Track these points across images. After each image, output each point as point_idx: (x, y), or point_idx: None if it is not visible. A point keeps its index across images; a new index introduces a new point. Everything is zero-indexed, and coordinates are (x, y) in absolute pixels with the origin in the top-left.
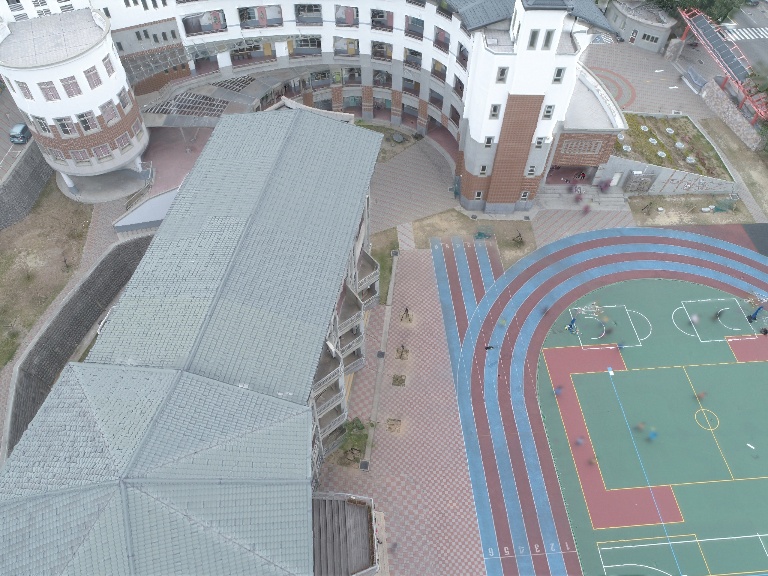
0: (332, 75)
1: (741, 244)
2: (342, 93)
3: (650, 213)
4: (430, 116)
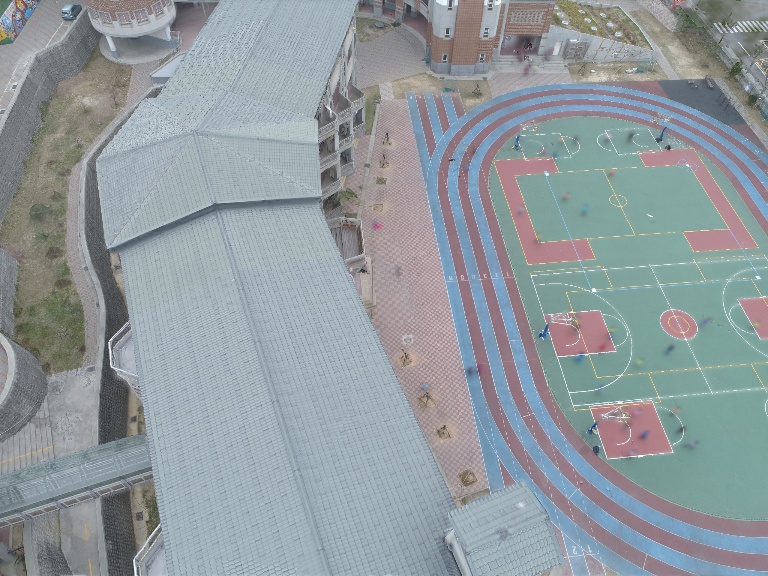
0: None
1: (656, 93)
2: None
3: (584, 74)
4: (405, 3)
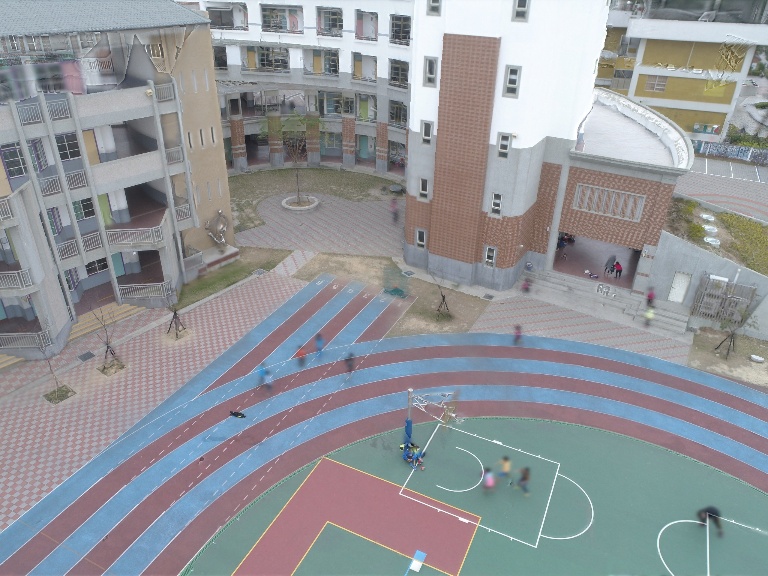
0: (345, 101)
1: None
2: (355, 128)
3: (730, 357)
4: None
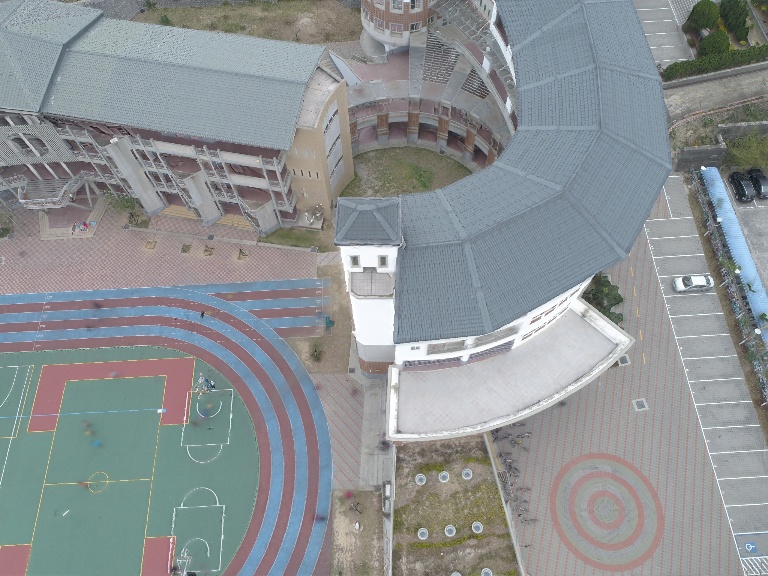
0: None
1: None
2: None
3: (353, 511)
4: None
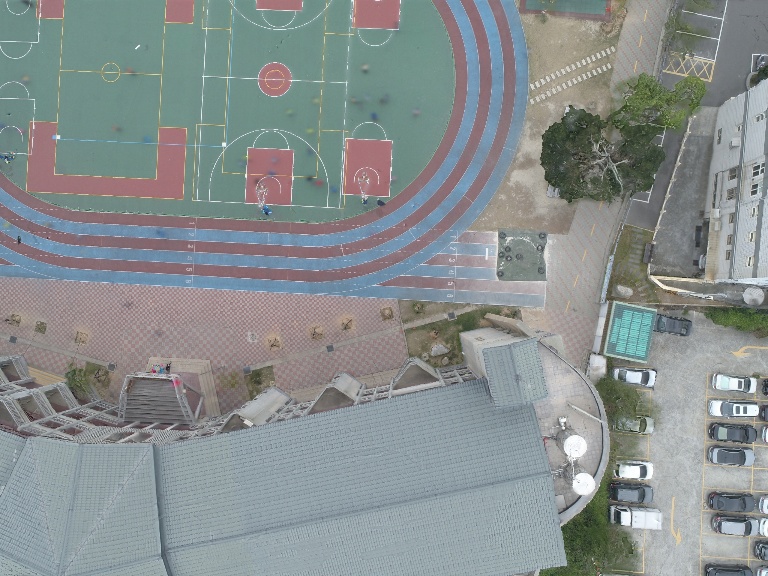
0: None
1: None
2: None
3: None
4: None
